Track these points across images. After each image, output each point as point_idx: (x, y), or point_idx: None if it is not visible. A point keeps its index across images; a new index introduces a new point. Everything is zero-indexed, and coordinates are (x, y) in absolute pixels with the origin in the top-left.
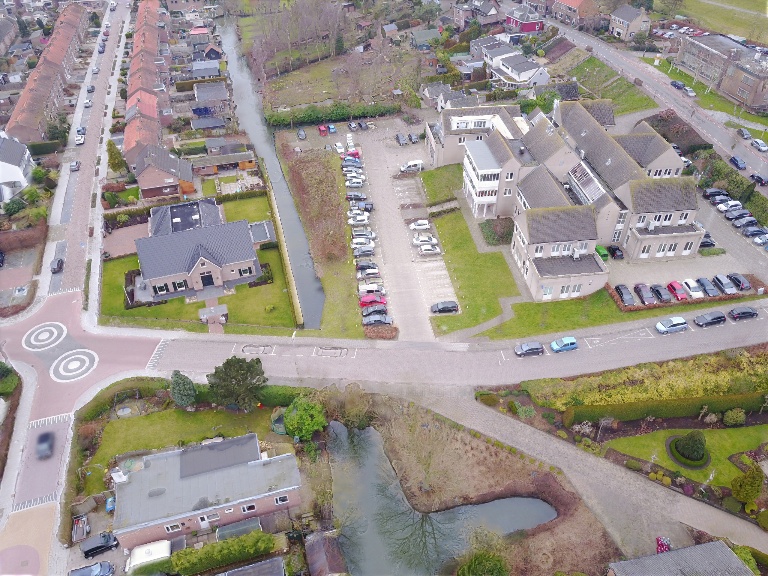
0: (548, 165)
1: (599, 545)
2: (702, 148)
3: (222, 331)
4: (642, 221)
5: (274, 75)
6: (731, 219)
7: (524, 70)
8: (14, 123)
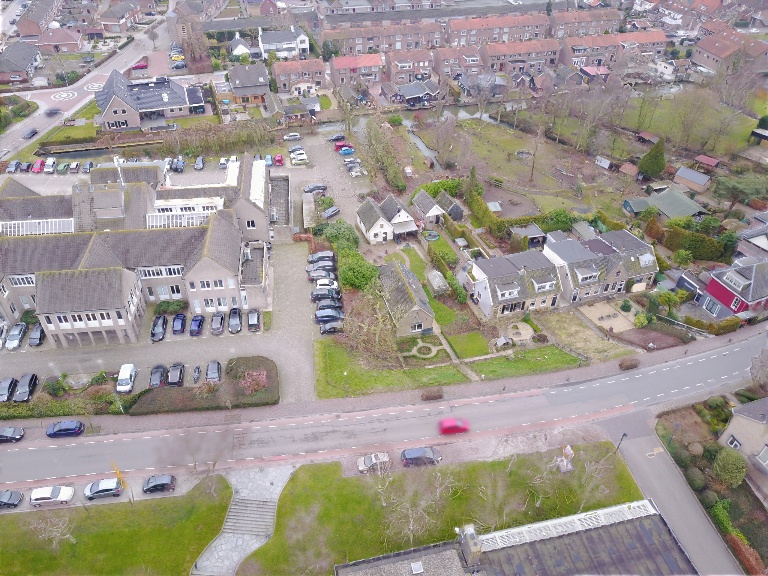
0: None
1: None
2: None
3: None
4: None
5: (506, 123)
6: None
7: (482, 264)
8: (320, 30)
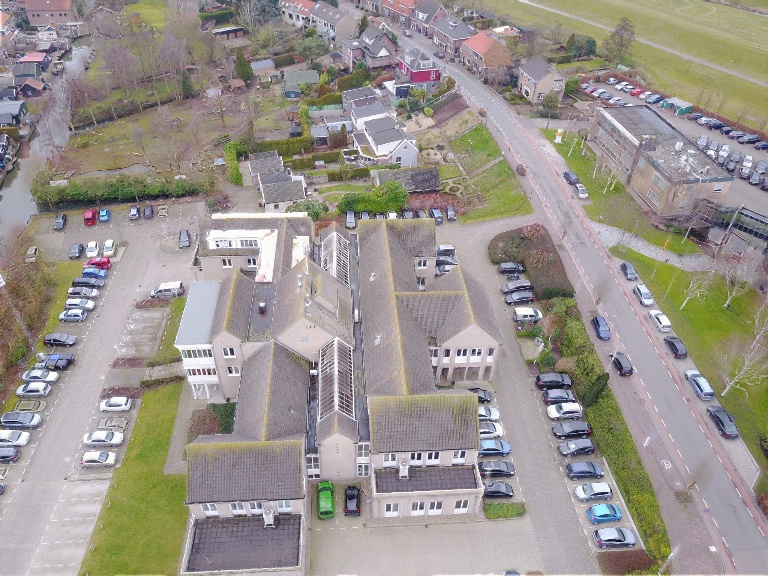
0: (284, 341)
1: None
2: (560, 295)
3: None
4: (393, 458)
5: (93, 123)
6: (559, 436)
7: (383, 142)
8: None
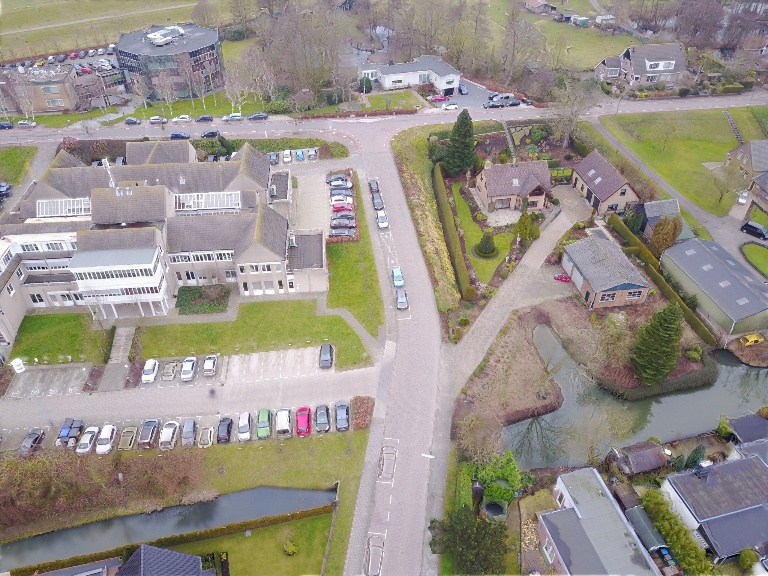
0: (167, 215)
1: (568, 305)
2: None
3: None
4: None
5: None
6: None
7: None
8: None
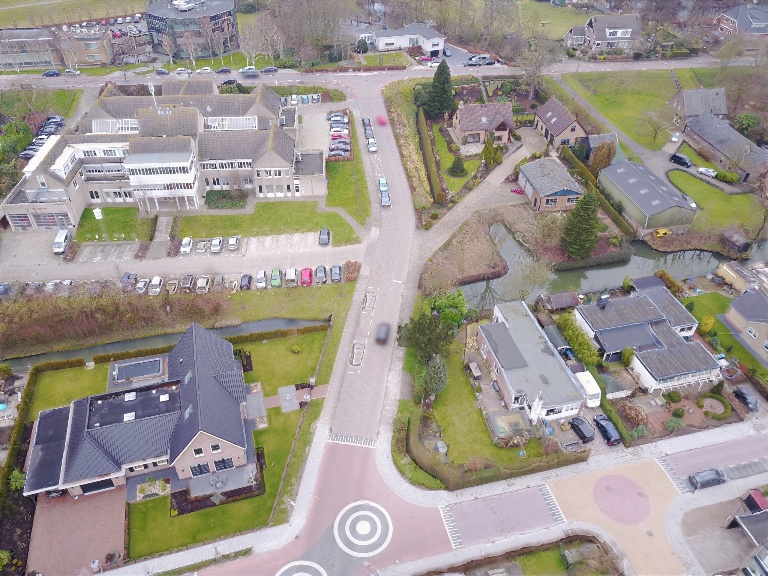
0: None
1: (519, 209)
2: None
3: (325, 386)
4: None
5: None
6: None
7: None
8: None
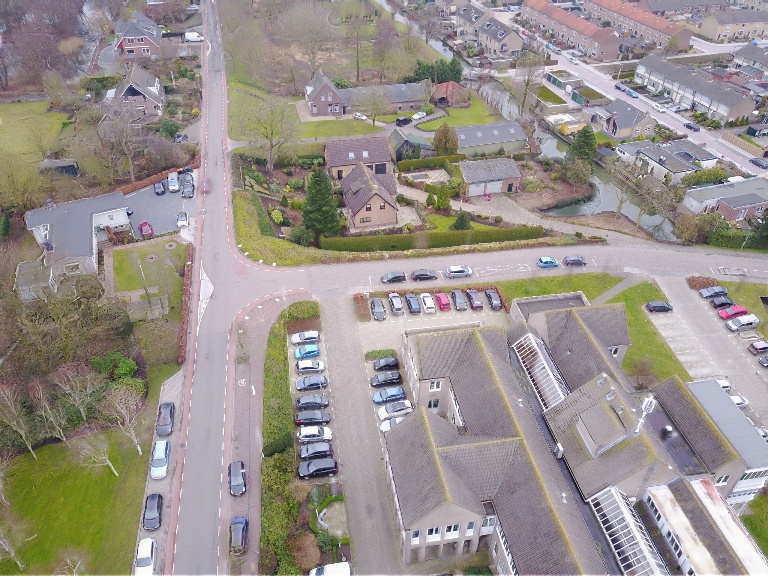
0: None
1: None
2: None
3: None
4: None
5: None
6: None
7: None
8: None
